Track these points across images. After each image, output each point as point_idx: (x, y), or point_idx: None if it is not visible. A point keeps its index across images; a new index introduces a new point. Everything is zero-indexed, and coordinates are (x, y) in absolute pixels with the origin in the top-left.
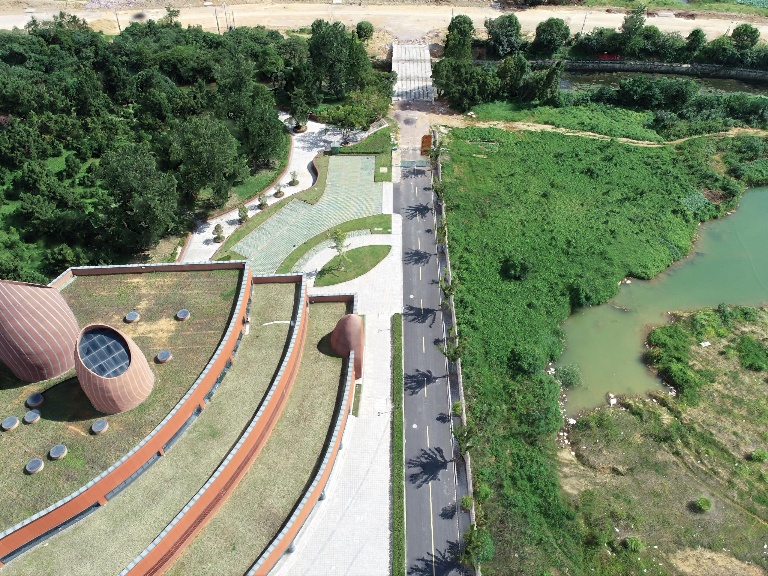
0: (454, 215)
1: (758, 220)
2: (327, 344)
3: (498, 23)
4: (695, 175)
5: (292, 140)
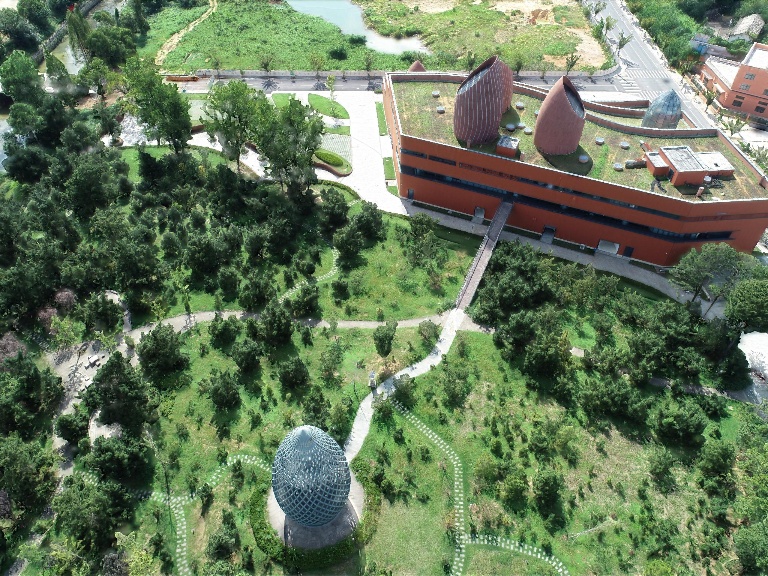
0: (282, 69)
1: (292, 1)
2: None
3: (9, 19)
4: (255, 2)
5: None
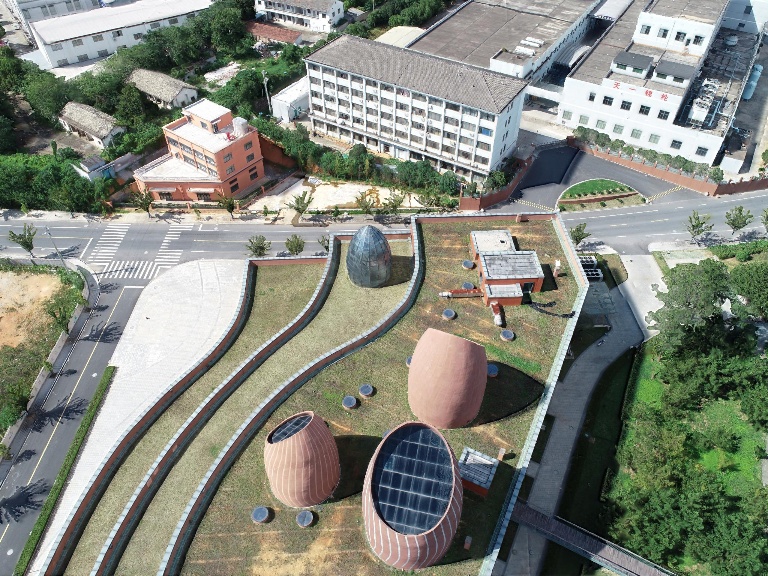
0: None
1: None
2: None
3: None
4: None
5: None
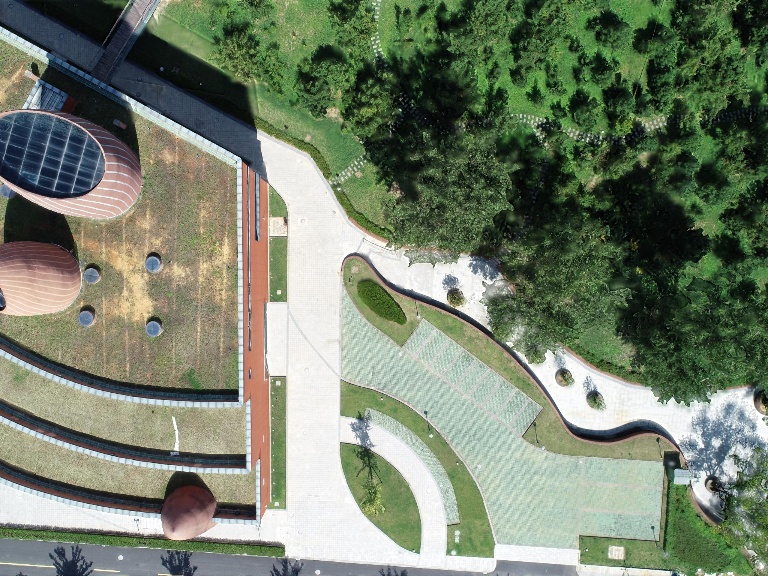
0: None
1: None
2: (187, 481)
3: None
4: None
5: (731, 389)
